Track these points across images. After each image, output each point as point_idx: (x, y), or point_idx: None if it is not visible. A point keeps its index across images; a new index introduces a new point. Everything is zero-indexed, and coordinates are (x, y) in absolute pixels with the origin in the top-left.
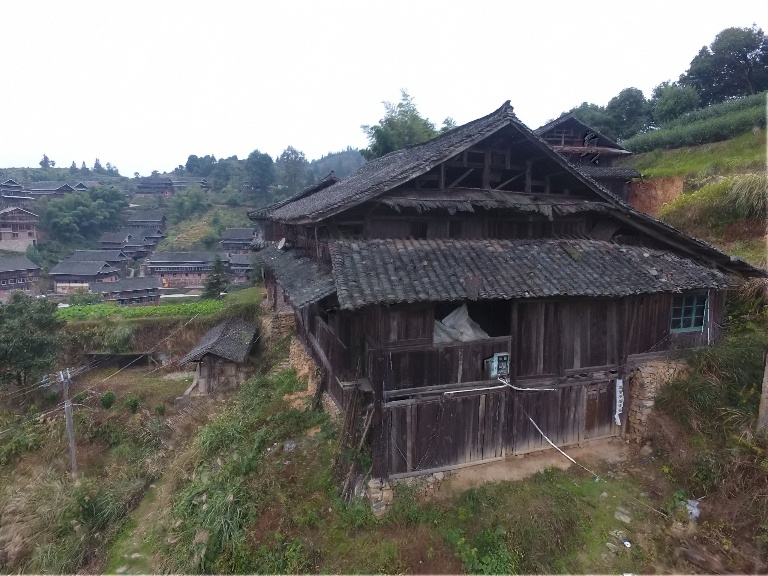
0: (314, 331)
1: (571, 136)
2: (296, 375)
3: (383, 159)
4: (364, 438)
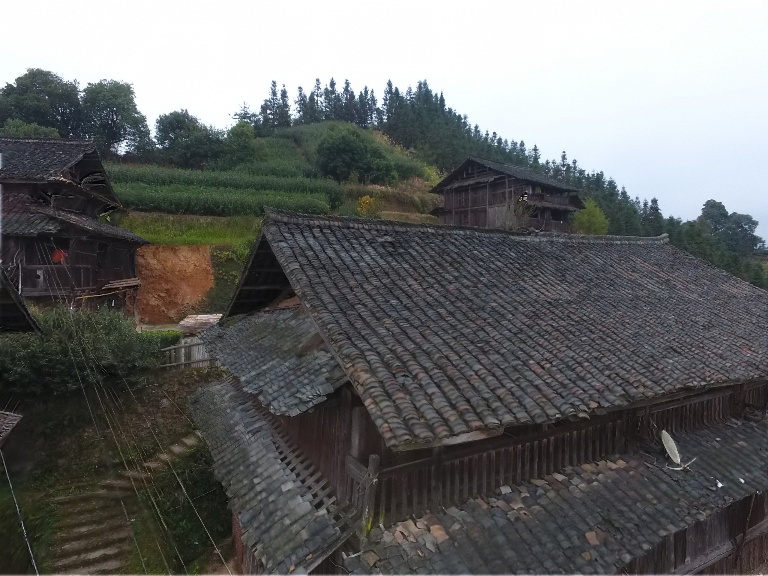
0: None
1: (73, 173)
2: None
3: (451, 232)
4: None
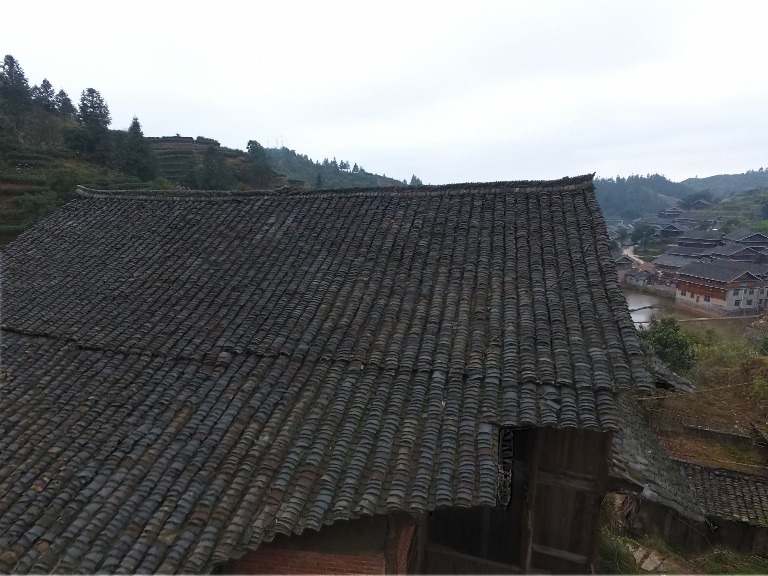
0: None
1: None
2: None
3: None
4: None
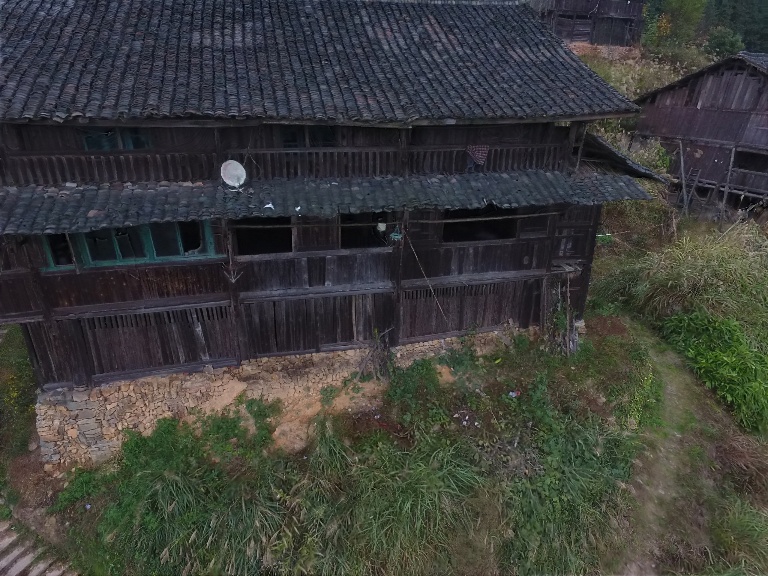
0: (441, 268)
1: None
2: (201, 417)
3: None
4: (568, 302)
